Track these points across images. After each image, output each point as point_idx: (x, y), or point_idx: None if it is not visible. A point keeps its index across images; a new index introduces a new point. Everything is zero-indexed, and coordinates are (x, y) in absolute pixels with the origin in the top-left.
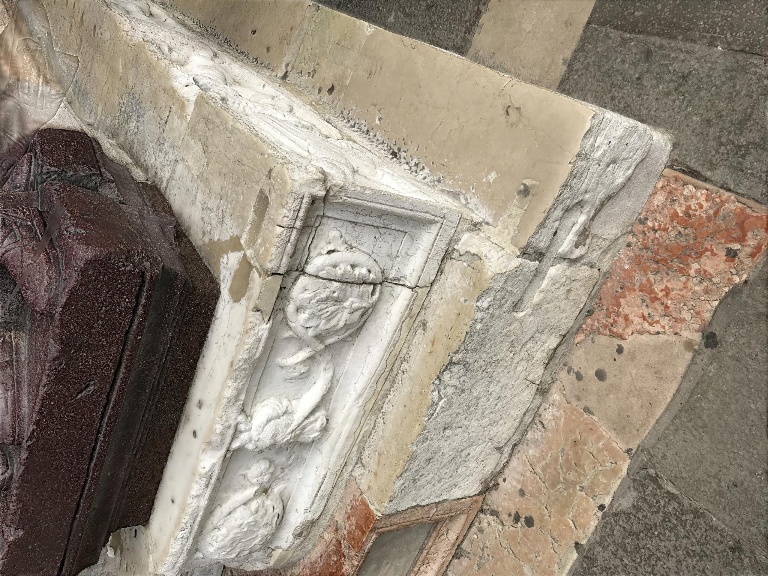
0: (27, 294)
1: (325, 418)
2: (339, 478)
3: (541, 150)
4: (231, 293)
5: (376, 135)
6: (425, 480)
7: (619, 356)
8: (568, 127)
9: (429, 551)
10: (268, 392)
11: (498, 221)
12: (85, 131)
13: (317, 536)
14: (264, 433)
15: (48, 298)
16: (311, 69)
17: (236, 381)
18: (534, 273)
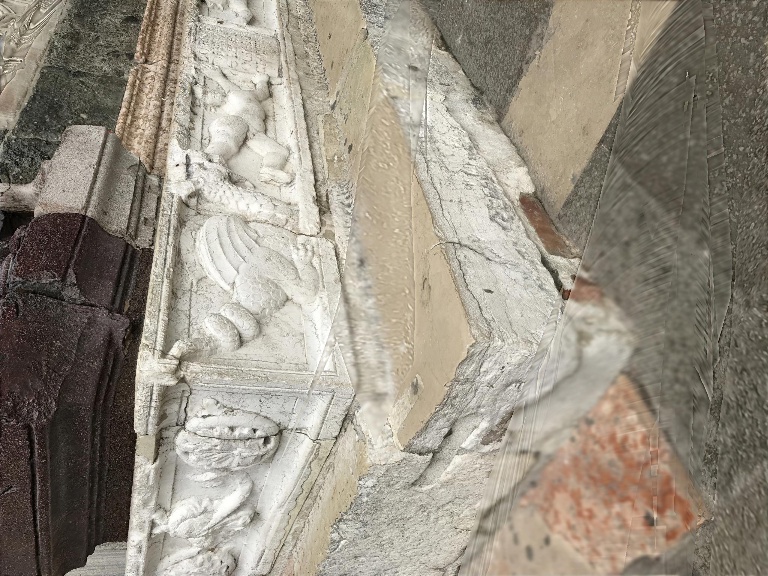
0: None
1: (249, 517)
2: (281, 552)
3: (431, 353)
4: None
5: None
6: None
7: None
8: (450, 345)
9: None
10: (188, 493)
11: (395, 402)
12: (90, 206)
13: None
14: (179, 529)
15: None
16: (346, 112)
17: (140, 495)
18: (428, 464)
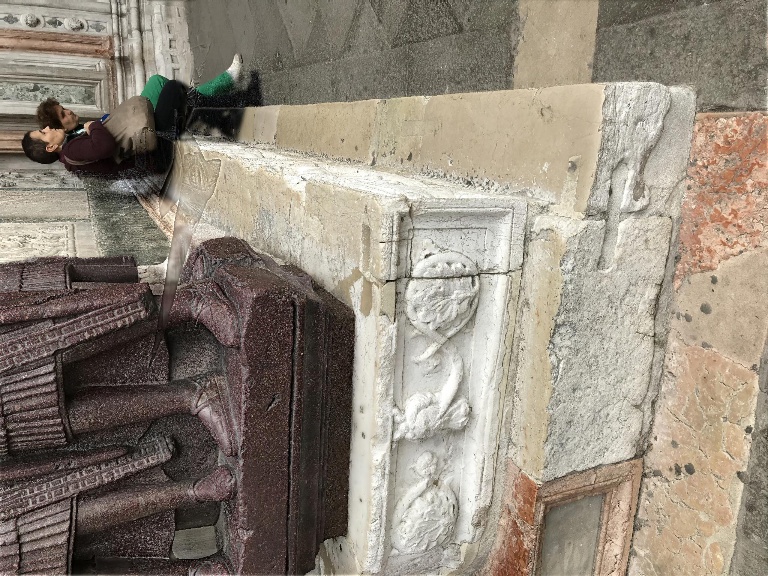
0: (219, 335)
1: (467, 404)
2: (497, 462)
3: (575, 130)
4: (362, 311)
5: (452, 175)
6: (573, 444)
7: (715, 286)
8: (589, 104)
9: (607, 527)
10: (413, 388)
11: (560, 198)
12: None
13: (495, 525)
14: (417, 421)
15: (234, 333)
16: (391, 148)
17: (383, 378)
18: (604, 230)
